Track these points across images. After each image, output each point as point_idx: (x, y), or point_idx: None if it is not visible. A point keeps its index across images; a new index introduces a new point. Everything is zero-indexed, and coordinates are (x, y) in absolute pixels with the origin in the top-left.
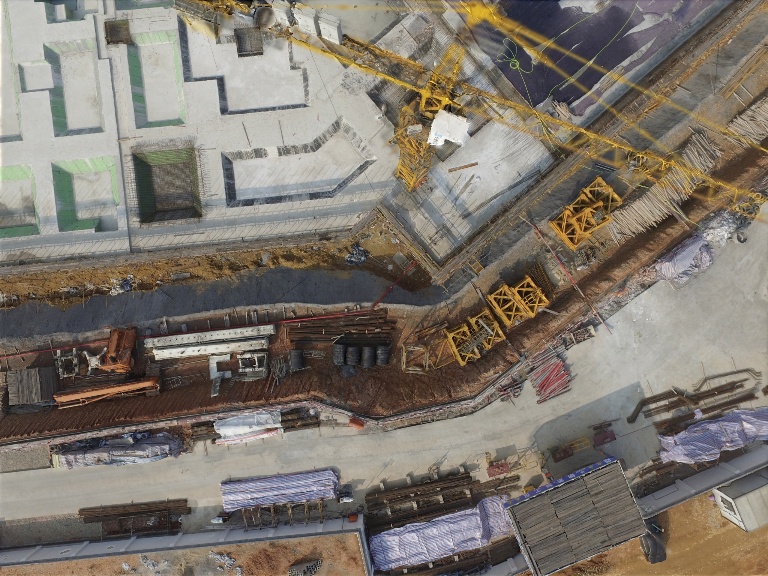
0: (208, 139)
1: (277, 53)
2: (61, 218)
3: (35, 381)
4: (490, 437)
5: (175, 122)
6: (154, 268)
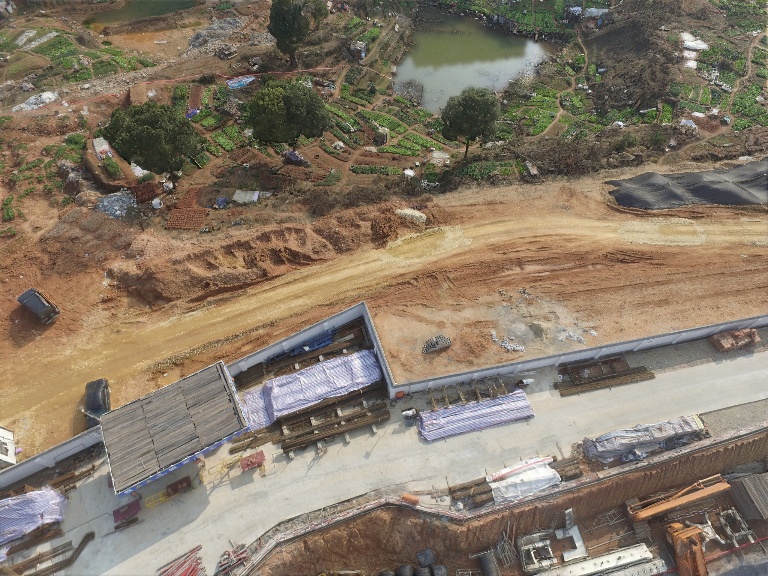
0: None
1: None
2: None
3: (759, 503)
4: (260, 496)
5: None
6: None
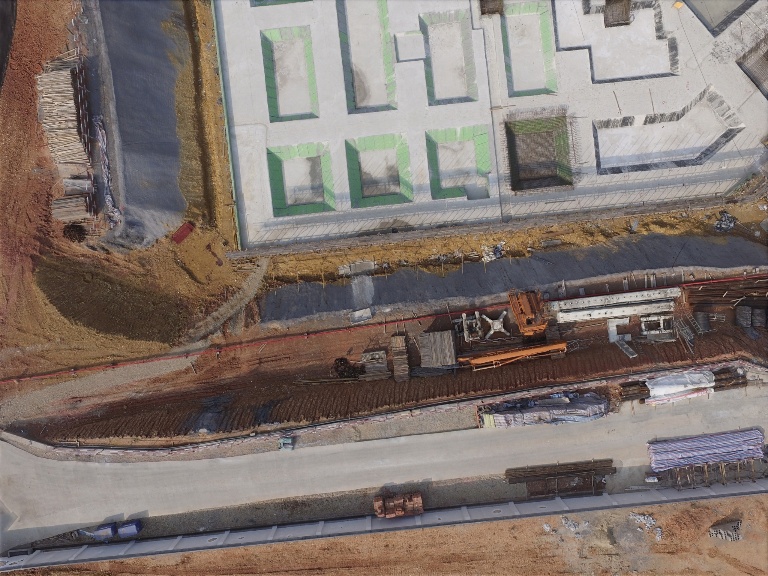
0: (579, 107)
1: (643, 23)
2: (432, 186)
3: (449, 343)
4: None
5: (544, 91)
6: (528, 235)
